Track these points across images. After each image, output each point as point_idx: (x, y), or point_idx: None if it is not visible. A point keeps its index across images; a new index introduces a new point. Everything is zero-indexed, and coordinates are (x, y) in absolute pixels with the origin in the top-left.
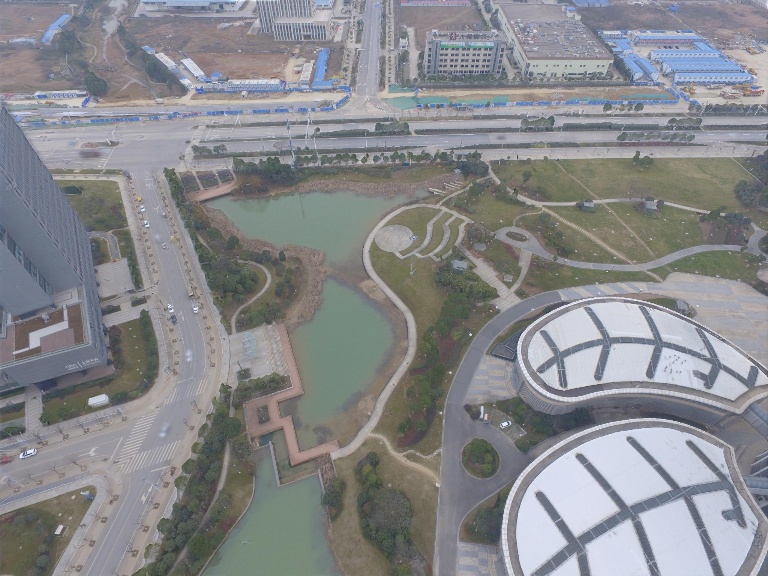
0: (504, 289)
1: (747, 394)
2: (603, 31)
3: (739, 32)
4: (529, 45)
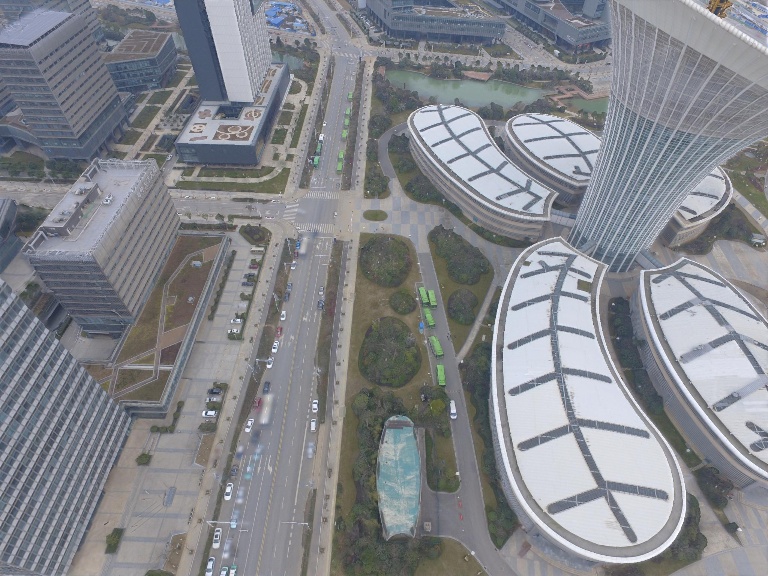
0: None
1: None
2: None
3: None
4: None
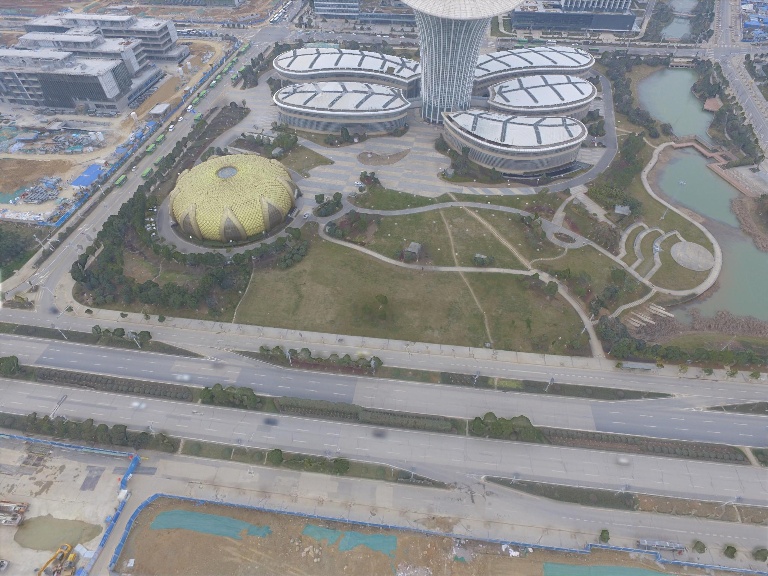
0: (580, 197)
1: None
2: None
3: None
4: None
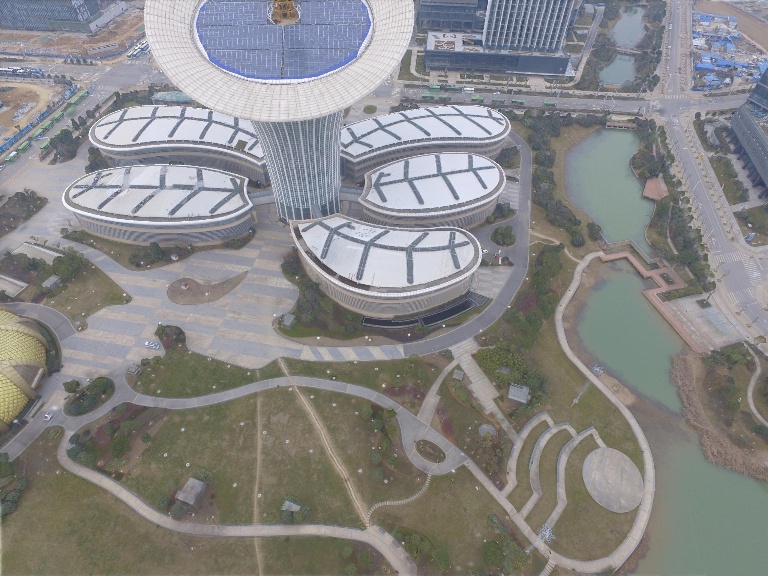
0: (465, 364)
1: None
2: None
3: None
4: None
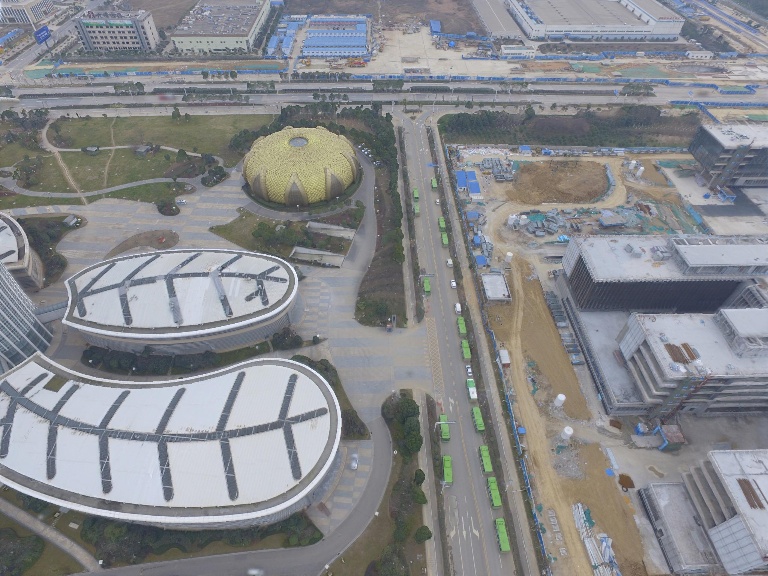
0: None
1: None
2: (291, 15)
3: (415, 16)
4: (187, 25)
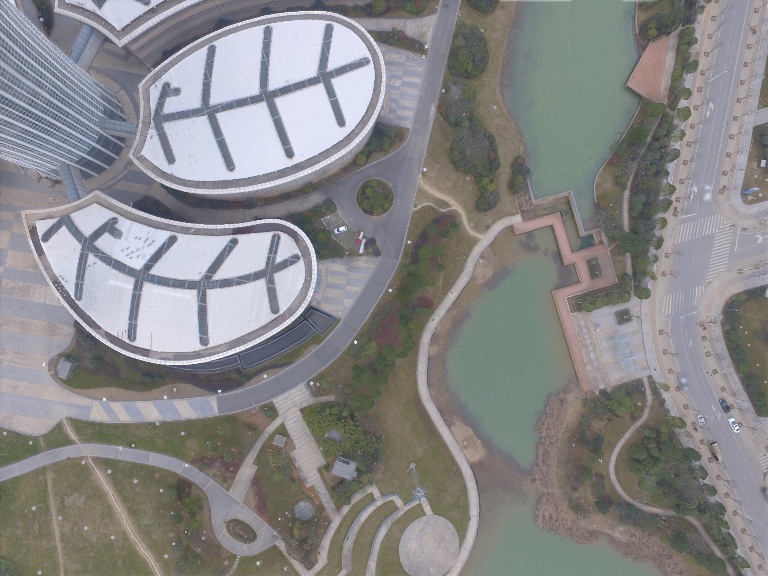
0: (290, 422)
1: (75, 210)
2: None
3: None
4: None
